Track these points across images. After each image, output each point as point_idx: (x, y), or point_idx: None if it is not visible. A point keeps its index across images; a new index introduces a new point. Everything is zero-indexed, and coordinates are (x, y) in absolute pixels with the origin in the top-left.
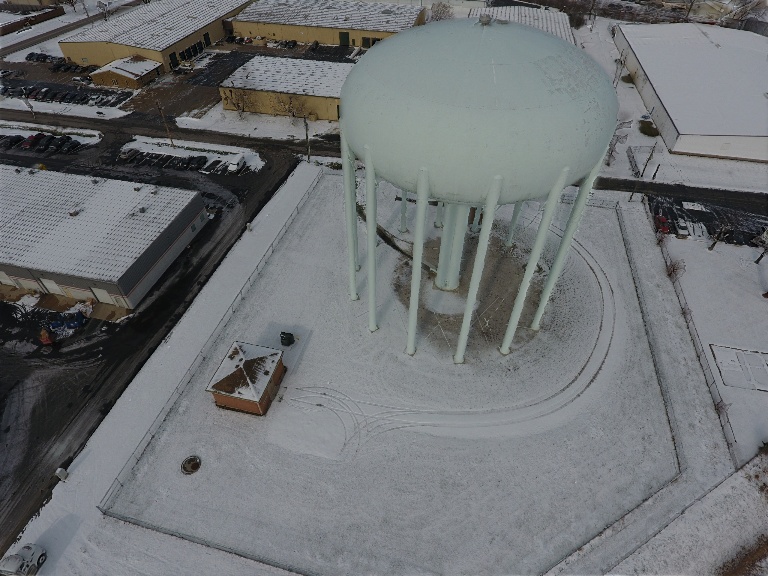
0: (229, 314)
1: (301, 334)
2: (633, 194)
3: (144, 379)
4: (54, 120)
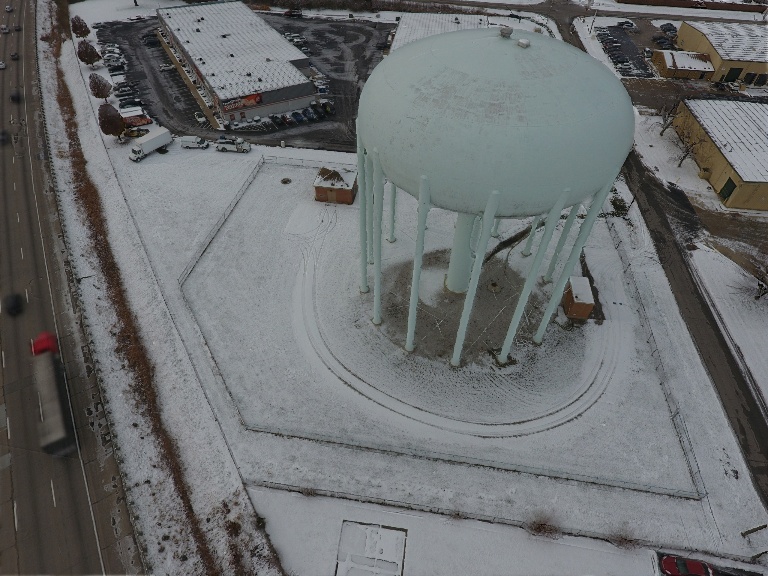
0: None
1: None
2: None
3: (340, 155)
4: None
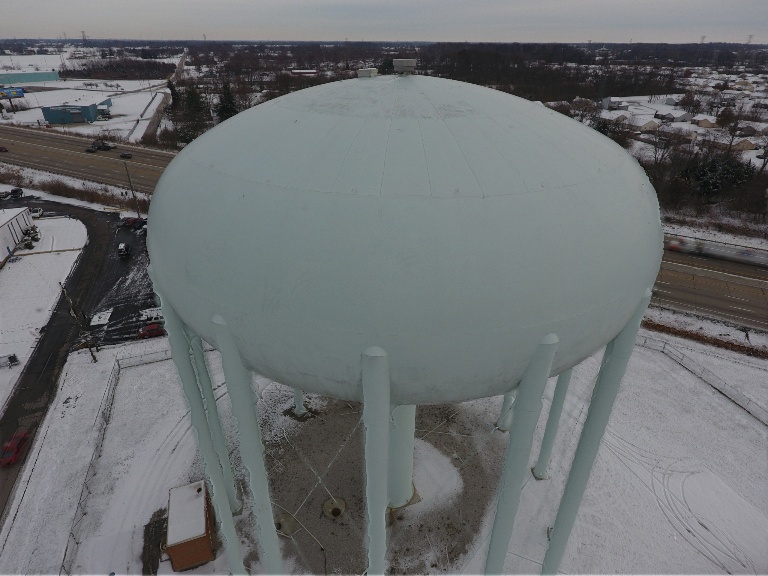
0: None
1: None
2: (75, 359)
3: None
4: None
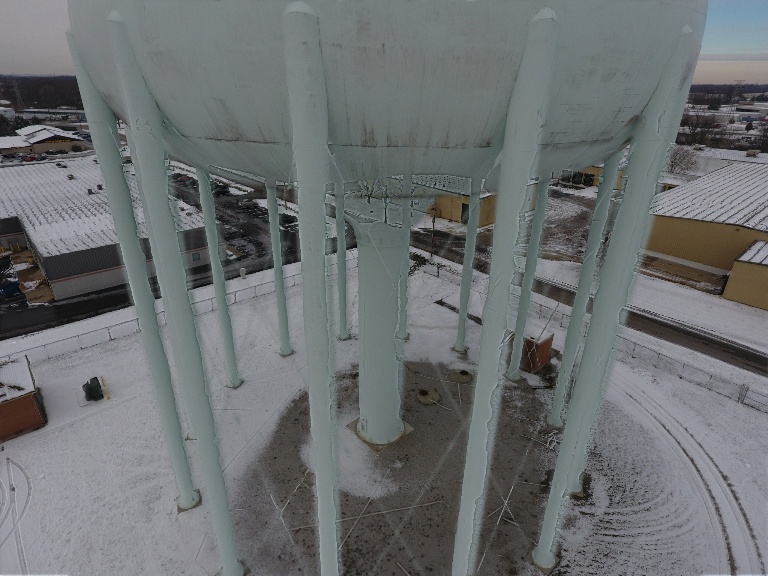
0: (105, 339)
1: (120, 394)
2: None
3: None
4: (238, 179)
